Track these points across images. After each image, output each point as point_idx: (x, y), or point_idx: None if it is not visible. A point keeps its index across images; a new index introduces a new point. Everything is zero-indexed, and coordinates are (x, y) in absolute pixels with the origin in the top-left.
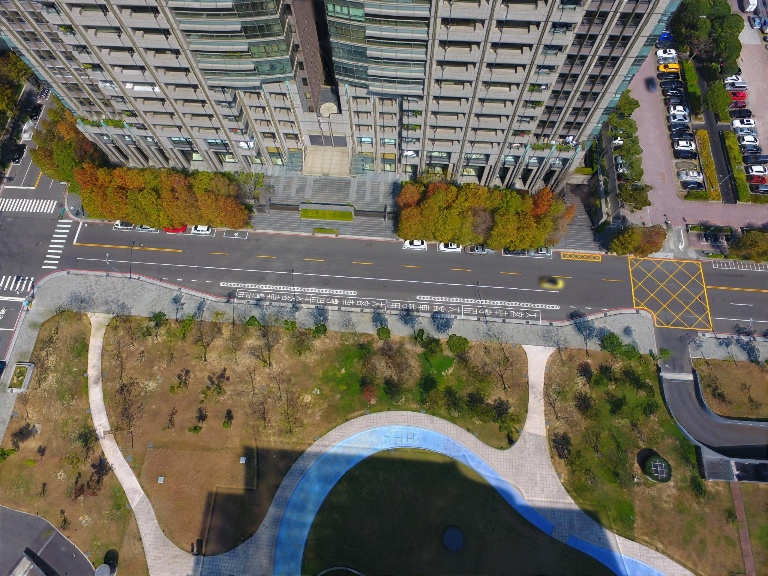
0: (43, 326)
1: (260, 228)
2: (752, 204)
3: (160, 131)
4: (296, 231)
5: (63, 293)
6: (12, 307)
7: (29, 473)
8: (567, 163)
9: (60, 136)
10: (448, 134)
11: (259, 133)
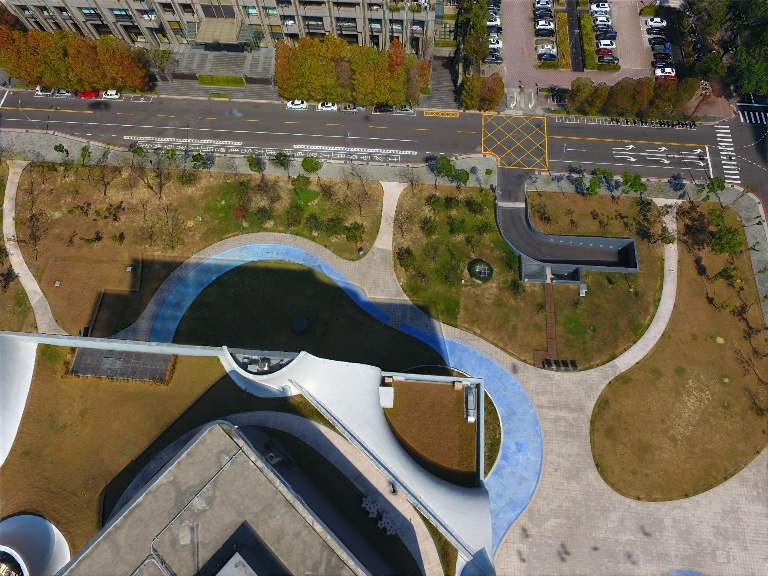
0: None
1: (163, 94)
2: (598, 72)
3: (69, 0)
4: (194, 96)
5: None
6: None
7: None
8: (424, 27)
9: None
10: None
11: (158, 4)
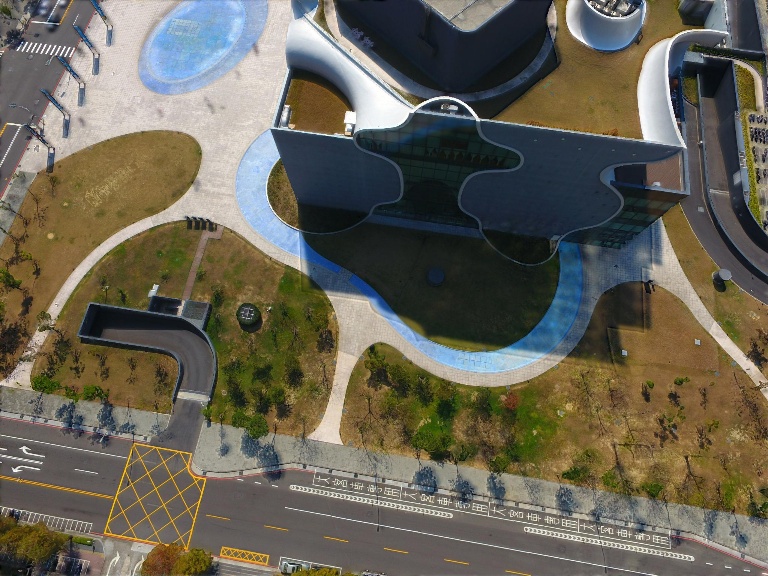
0: None
1: None
2: None
3: None
4: None
5: None
6: None
7: None
8: None
9: None
10: None
11: None
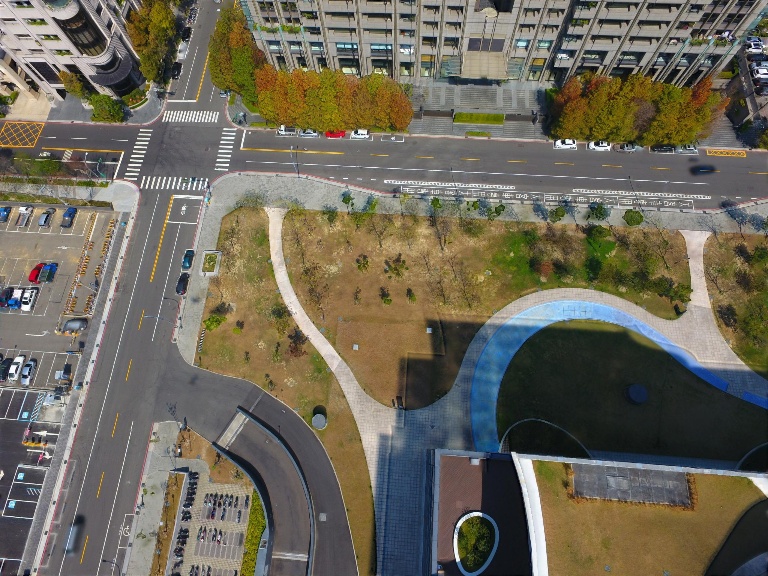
0: (224, 220)
1: (415, 132)
2: None
3: (332, 36)
4: (450, 135)
5: (238, 191)
6: (192, 204)
7: (232, 343)
8: (718, 60)
9: (229, 47)
10: (613, 29)
11: (421, 38)
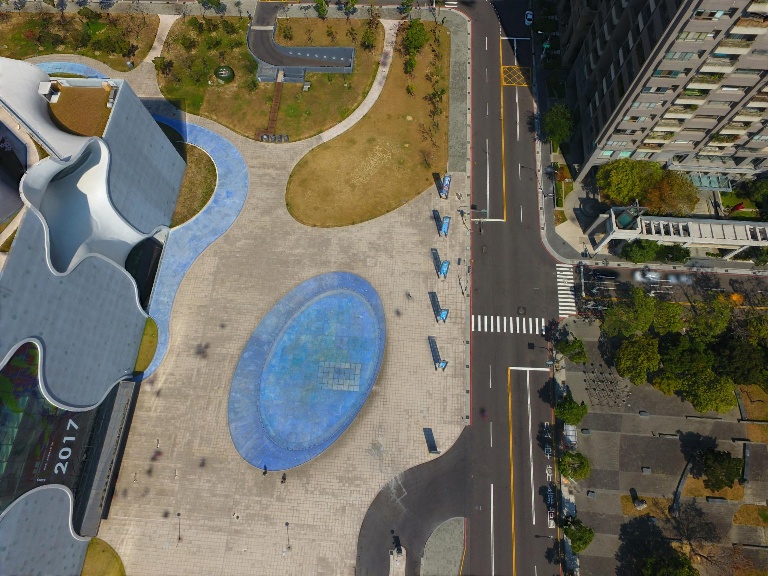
0: None
1: None
2: None
3: None
4: None
5: None
6: None
7: None
8: None
9: None
10: None
11: None
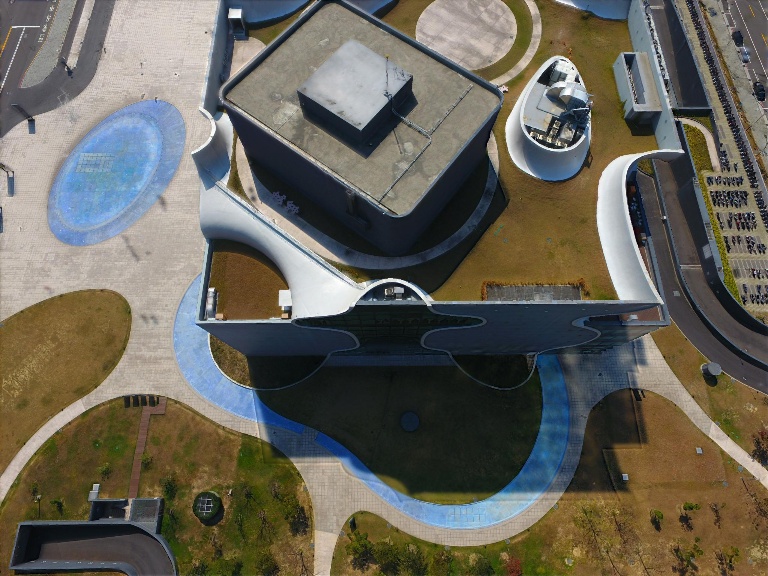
0: None
1: None
2: None
3: None
4: None
5: None
6: None
7: None
8: None
9: None
10: None
11: None
